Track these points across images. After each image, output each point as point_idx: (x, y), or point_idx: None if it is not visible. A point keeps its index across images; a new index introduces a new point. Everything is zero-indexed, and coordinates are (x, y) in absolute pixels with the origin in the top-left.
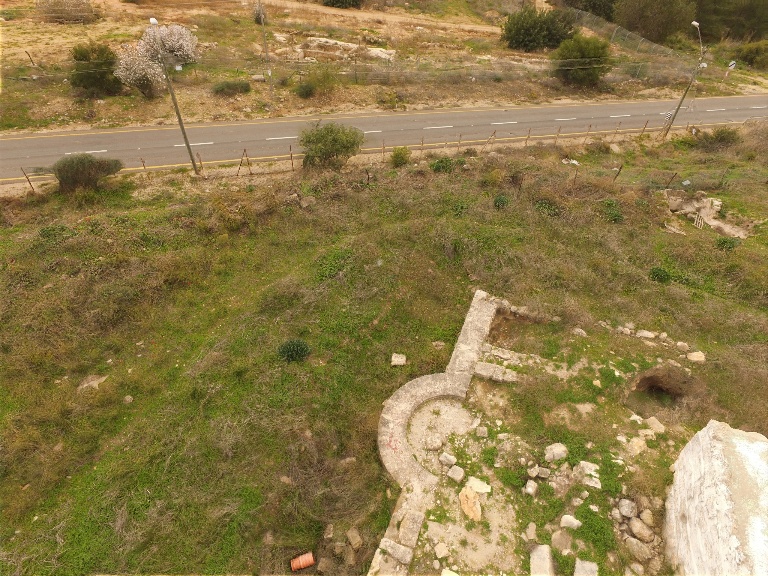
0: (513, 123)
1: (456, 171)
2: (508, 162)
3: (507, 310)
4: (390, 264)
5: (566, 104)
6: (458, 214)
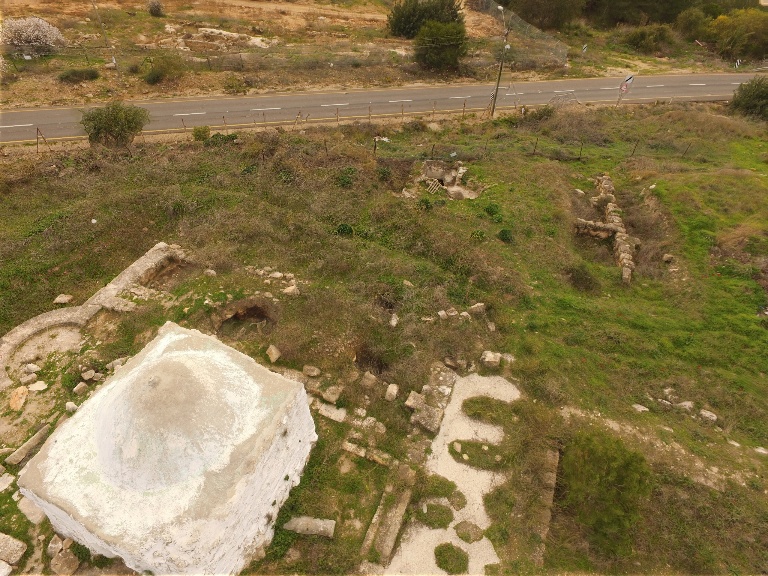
0: (344, 105)
1: (226, 145)
2: (280, 137)
3: (178, 258)
4: (102, 223)
5: (413, 87)
6: (200, 182)
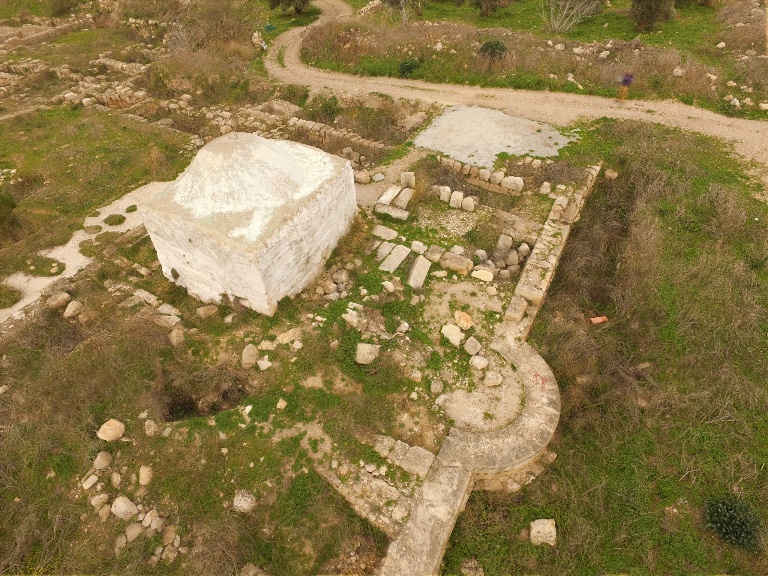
0: None
1: None
2: None
3: None
4: None
5: None
6: None
